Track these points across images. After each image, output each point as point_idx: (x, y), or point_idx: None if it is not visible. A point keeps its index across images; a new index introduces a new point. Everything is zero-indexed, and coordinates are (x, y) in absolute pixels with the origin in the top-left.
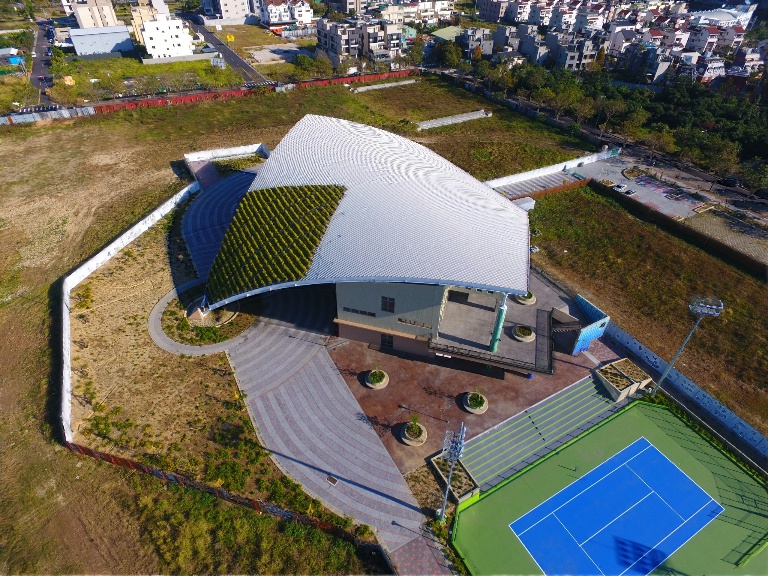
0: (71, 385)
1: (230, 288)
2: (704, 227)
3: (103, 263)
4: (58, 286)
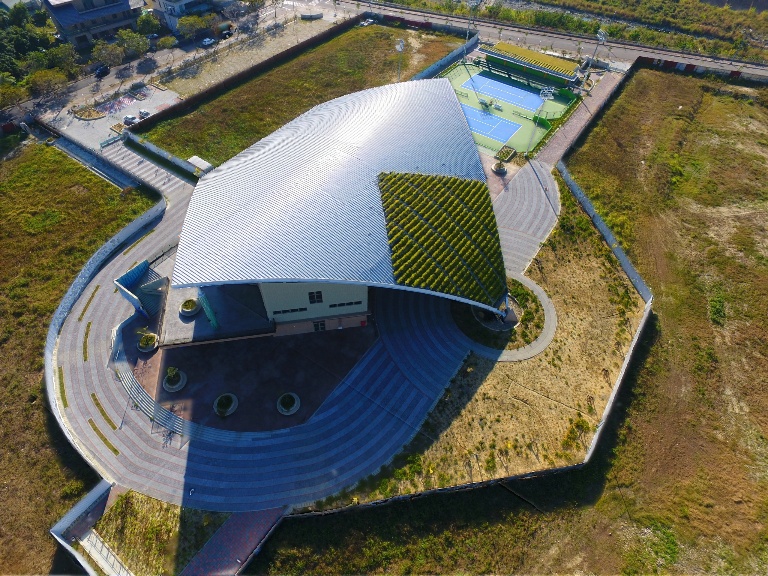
0: (630, 345)
1: (500, 260)
2: (192, 88)
3: (525, 479)
4: (589, 491)
